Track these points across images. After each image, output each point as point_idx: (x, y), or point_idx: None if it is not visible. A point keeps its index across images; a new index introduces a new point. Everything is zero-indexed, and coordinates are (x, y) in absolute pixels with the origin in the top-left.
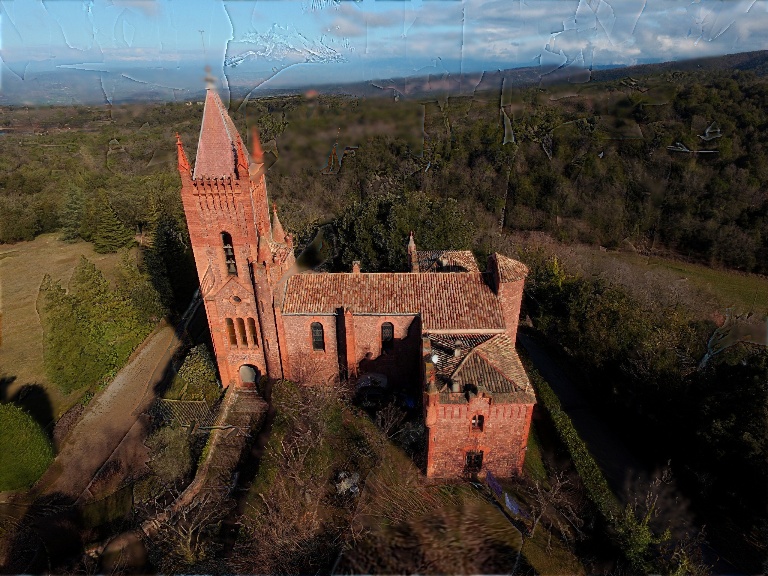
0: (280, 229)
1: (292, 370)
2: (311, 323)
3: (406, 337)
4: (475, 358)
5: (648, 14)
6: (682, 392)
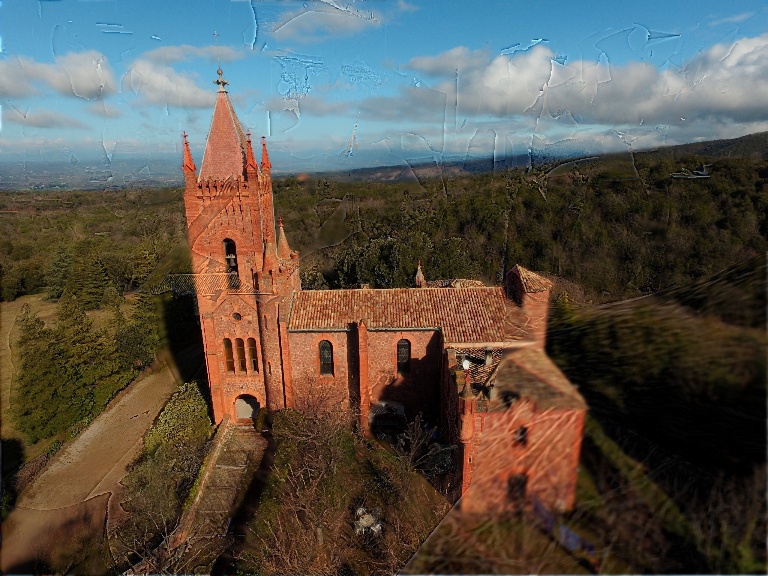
0: (286, 245)
1: (296, 399)
2: (319, 342)
3: (424, 357)
4: None
5: (633, 63)
6: None
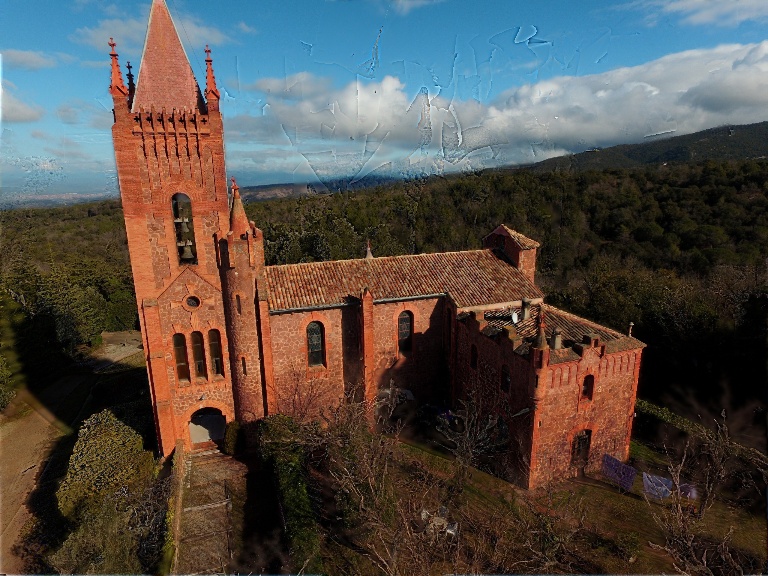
0: None
1: (278, 403)
2: (308, 324)
3: (428, 330)
4: (550, 316)
5: (528, 57)
6: (732, 330)
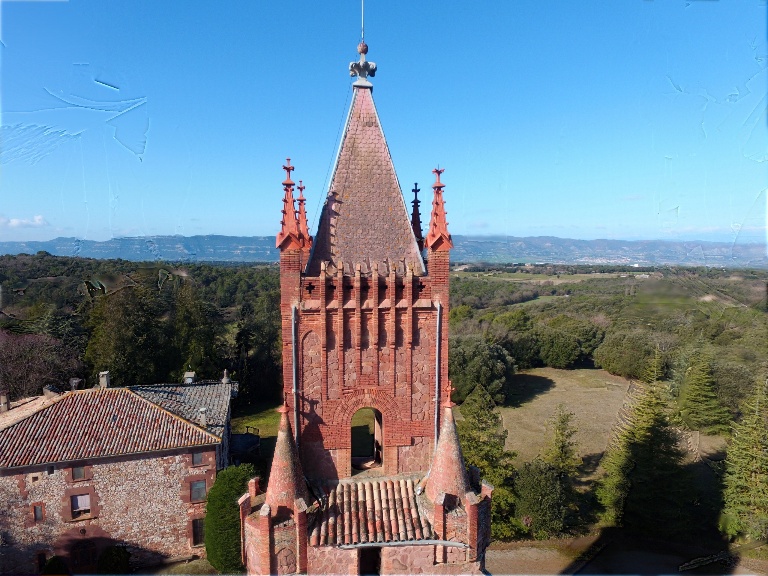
0: (443, 461)
1: None
2: None
3: None
4: None
5: None
6: None
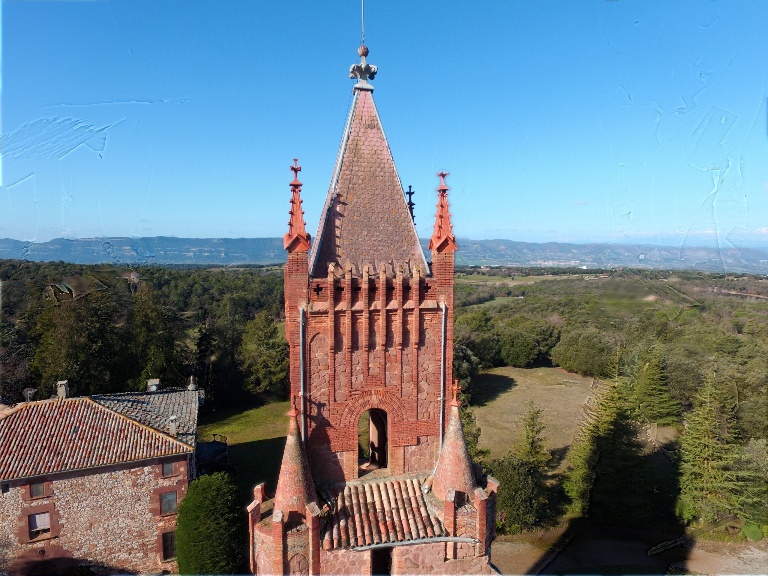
0: (451, 459)
1: None
2: None
3: None
4: None
5: None
6: None
